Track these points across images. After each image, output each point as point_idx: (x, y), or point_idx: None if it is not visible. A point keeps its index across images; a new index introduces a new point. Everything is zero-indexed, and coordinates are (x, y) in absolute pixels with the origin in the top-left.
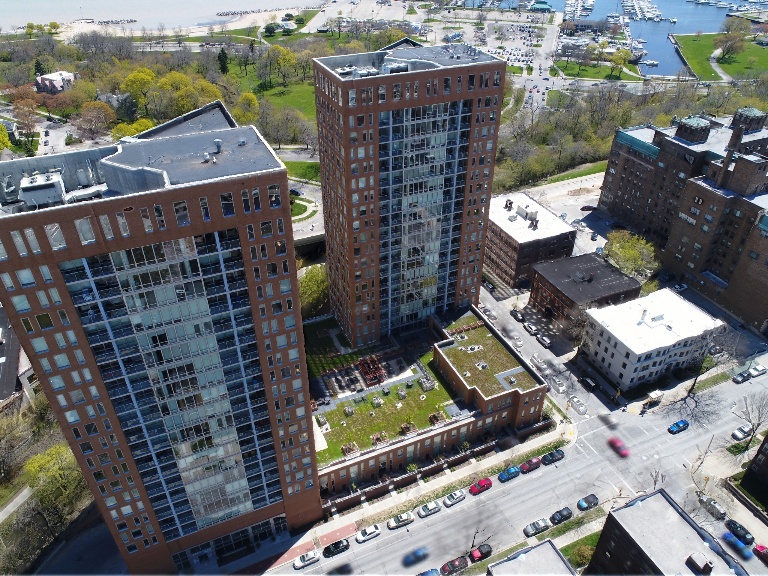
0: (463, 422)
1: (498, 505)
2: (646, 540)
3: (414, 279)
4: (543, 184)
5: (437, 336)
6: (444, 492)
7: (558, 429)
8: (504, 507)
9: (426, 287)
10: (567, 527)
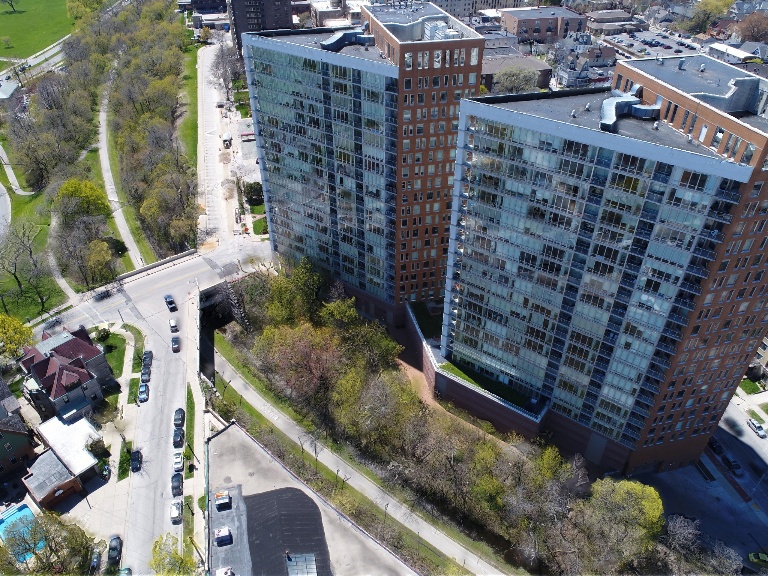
0: None
1: None
2: None
3: None
4: (195, 170)
5: None
6: None
7: None
8: None
9: None
10: None
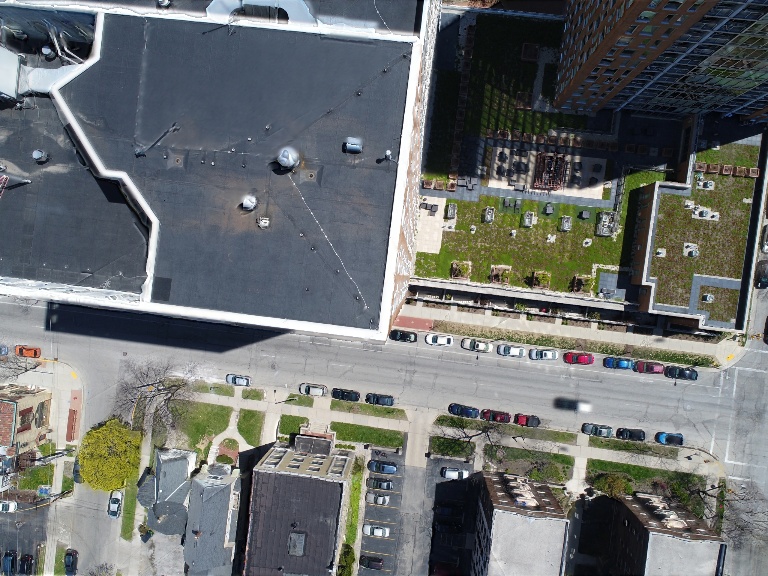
0: (607, 306)
1: (580, 386)
2: (657, 573)
3: (702, 84)
4: None
5: (681, 145)
6: (538, 341)
7: (720, 345)
8: (584, 392)
9: (715, 94)
10: (627, 447)
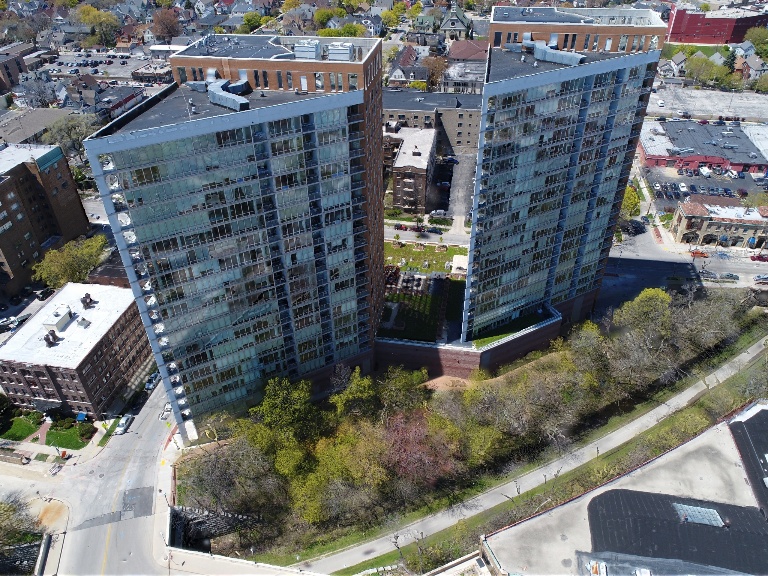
0: None
1: None
2: None
3: None
4: None
5: None
6: None
7: None
8: None
9: None
10: None
